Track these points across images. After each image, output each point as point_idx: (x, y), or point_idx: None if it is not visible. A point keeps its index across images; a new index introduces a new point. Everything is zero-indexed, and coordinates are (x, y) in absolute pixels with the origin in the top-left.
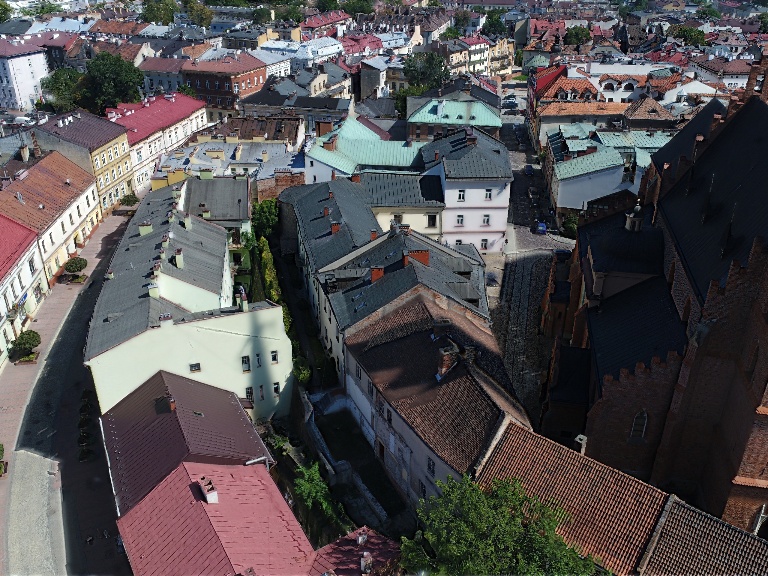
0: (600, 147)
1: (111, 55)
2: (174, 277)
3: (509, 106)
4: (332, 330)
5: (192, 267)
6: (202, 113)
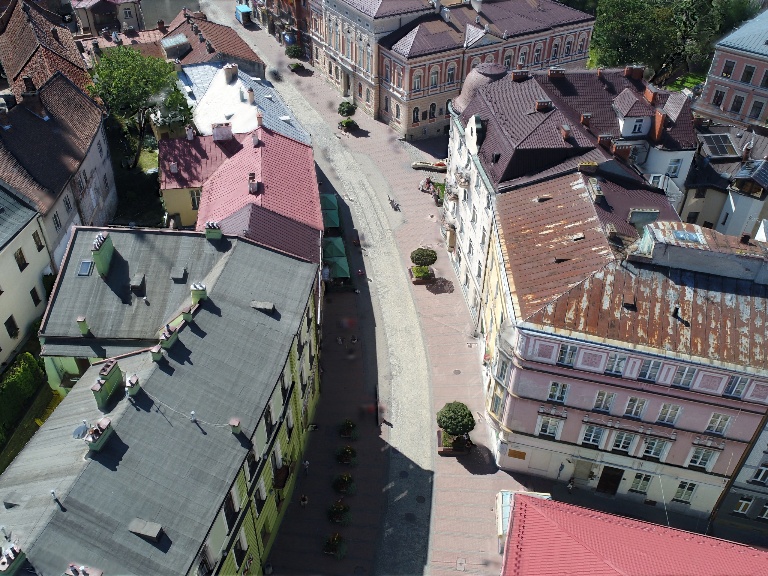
0: None
1: None
2: (147, 349)
3: None
4: (9, 292)
5: (92, 406)
6: None
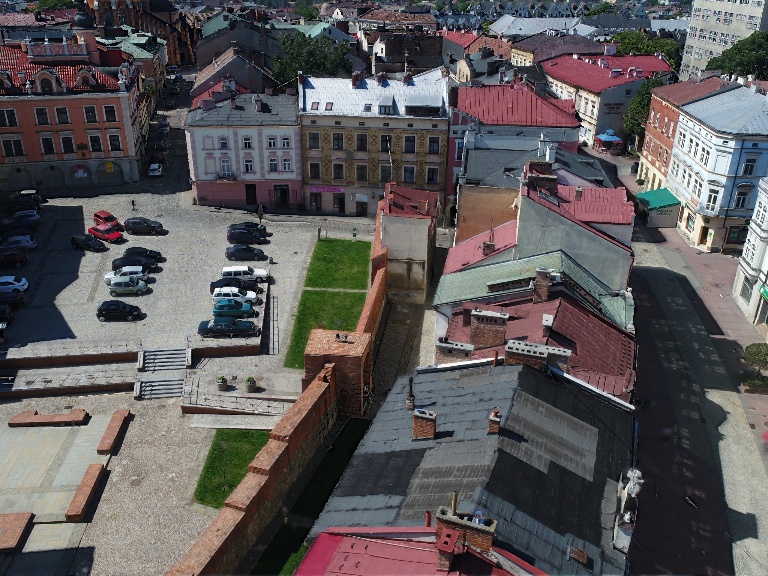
0: (128, 32)
1: (757, 36)
2: None
3: (144, 250)
4: None
5: None
6: (594, 100)
